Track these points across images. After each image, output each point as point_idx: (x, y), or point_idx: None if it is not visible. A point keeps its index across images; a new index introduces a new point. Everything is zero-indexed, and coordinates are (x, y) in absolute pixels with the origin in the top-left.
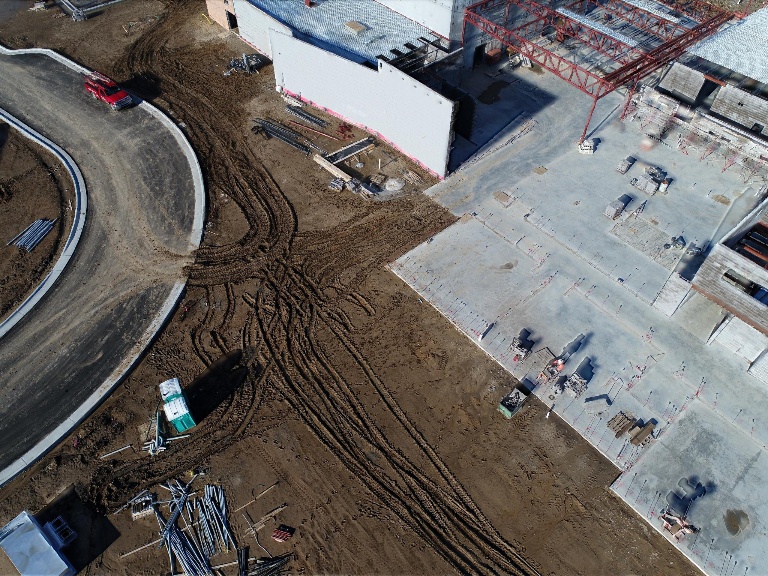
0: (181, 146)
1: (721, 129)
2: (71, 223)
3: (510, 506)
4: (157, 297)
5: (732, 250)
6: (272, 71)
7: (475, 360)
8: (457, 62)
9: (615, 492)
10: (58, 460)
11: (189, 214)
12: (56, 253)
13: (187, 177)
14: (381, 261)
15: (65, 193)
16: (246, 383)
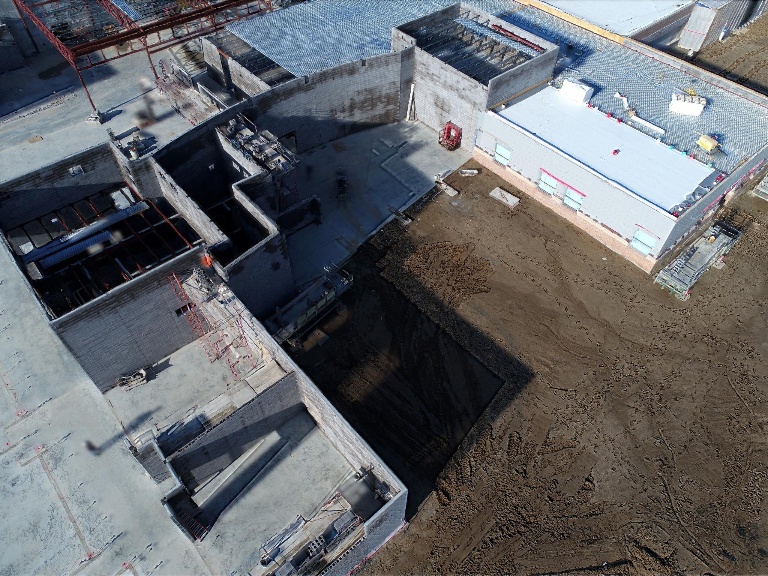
0: None
1: (200, 99)
2: None
3: None
4: None
5: None
6: None
7: None
8: (5, 38)
9: None
10: None
11: None
12: None
13: None
14: None
15: None
16: None
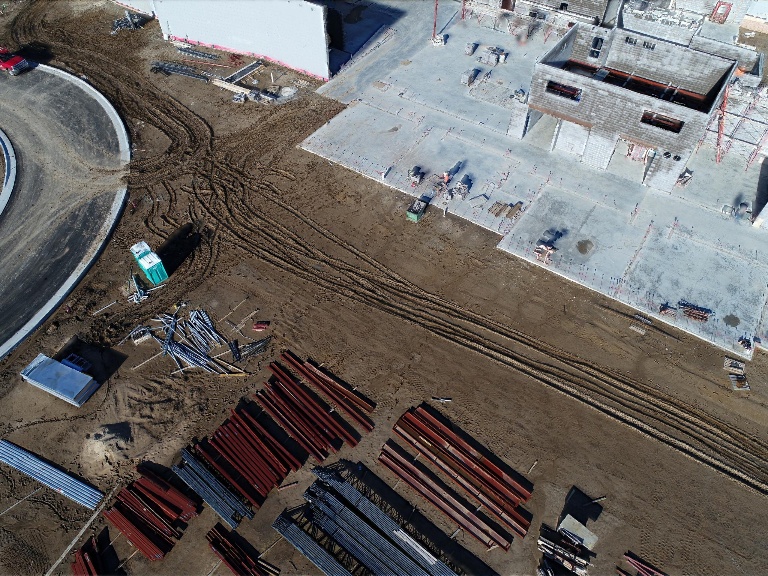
0: (88, 93)
1: (536, 8)
2: (3, 165)
3: (428, 273)
4: (104, 202)
5: (546, 65)
6: (155, 25)
7: (382, 193)
8: None
9: (501, 248)
10: (56, 324)
11: (113, 140)
12: None
13: (102, 114)
14: (291, 144)
15: None
16: (202, 243)
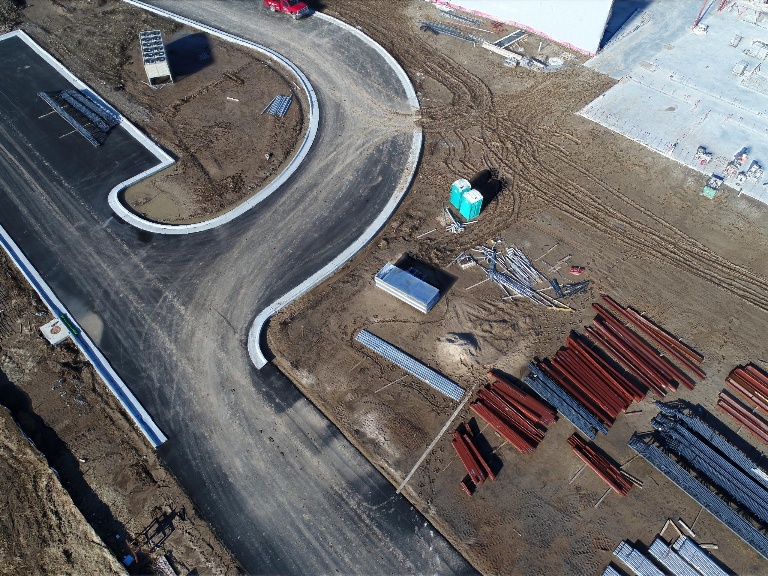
0: (366, 42)
1: None
2: (304, 98)
3: (732, 247)
4: (404, 141)
5: None
6: None
7: (671, 167)
8: None
9: None
10: (386, 240)
11: (399, 87)
12: (304, 118)
13: (383, 63)
14: (570, 110)
15: (287, 78)
16: (503, 189)
